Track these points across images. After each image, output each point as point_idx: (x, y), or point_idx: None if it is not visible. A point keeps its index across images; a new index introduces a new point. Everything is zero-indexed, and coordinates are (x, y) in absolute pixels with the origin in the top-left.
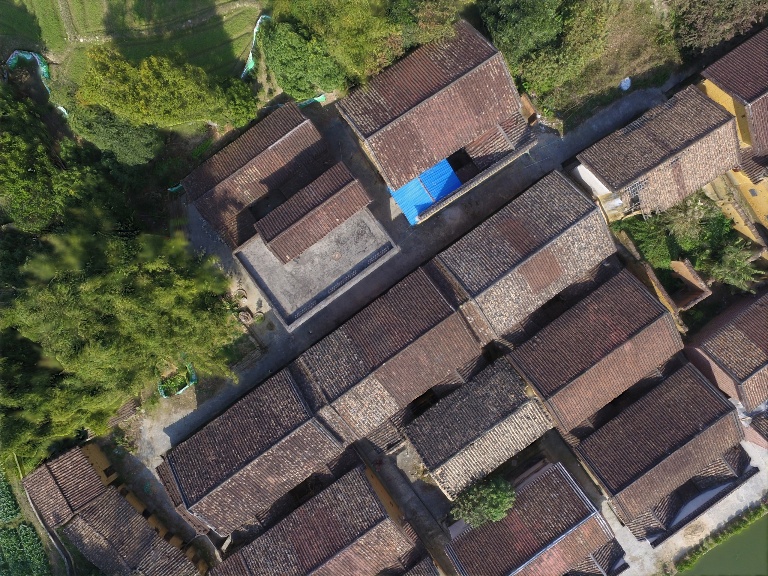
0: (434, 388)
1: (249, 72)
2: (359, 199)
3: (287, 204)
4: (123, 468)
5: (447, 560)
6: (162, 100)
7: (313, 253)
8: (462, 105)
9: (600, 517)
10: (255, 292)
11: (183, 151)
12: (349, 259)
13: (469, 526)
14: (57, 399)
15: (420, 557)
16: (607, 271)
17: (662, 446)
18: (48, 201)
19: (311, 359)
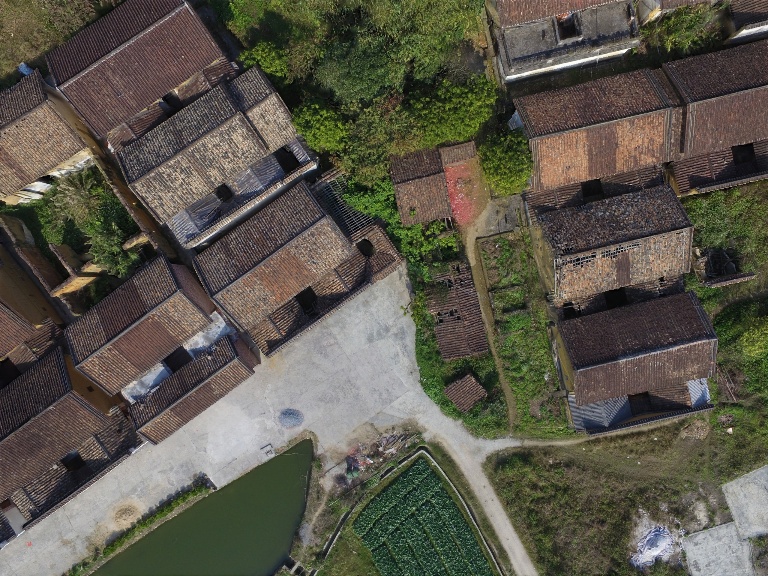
0: None
1: None
2: None
3: None
4: None
5: None
6: None
7: None
8: None
9: None
10: None
11: None
12: None
13: None
14: None
15: None
16: None
17: (6, 428)
18: None
19: None
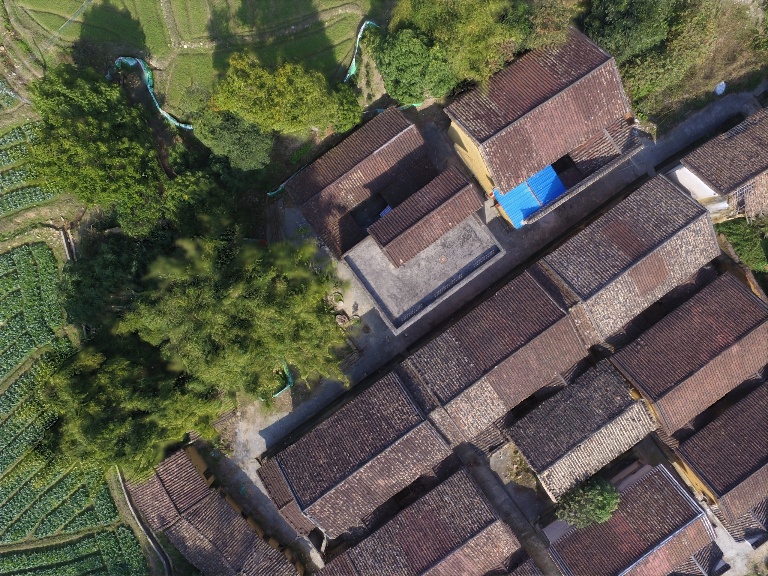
0: None
1: (351, 78)
2: (472, 203)
3: (400, 208)
4: (219, 471)
5: (540, 561)
6: (292, 106)
7: (419, 257)
8: (573, 110)
9: (706, 518)
10: (351, 295)
11: (282, 156)
12: (455, 263)
13: (572, 528)
14: (178, 402)
15: (521, 559)
16: (706, 274)
17: (767, 447)
18: (158, 206)
19: (419, 362)
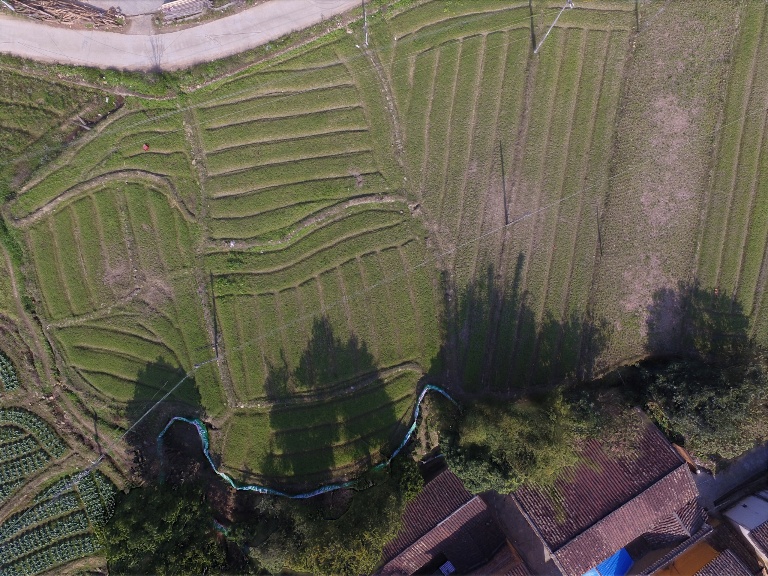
0: None
1: (412, 437)
2: None
3: None
4: None
5: None
6: None
7: None
8: (644, 507)
9: None
10: None
11: (338, 503)
12: None
13: None
14: None
15: None
16: None
17: None
18: None
19: None
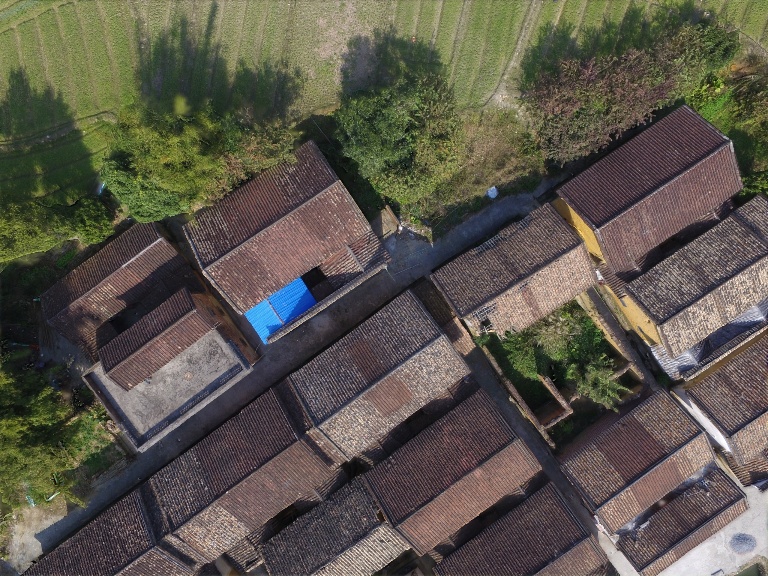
0: (295, 503)
1: None
2: (201, 327)
3: (130, 331)
4: None
5: None
6: None
7: (165, 373)
8: (305, 231)
9: None
10: None
11: (49, 261)
12: (201, 379)
13: None
14: None
15: None
16: (468, 387)
17: (517, 571)
18: None
19: (161, 482)
